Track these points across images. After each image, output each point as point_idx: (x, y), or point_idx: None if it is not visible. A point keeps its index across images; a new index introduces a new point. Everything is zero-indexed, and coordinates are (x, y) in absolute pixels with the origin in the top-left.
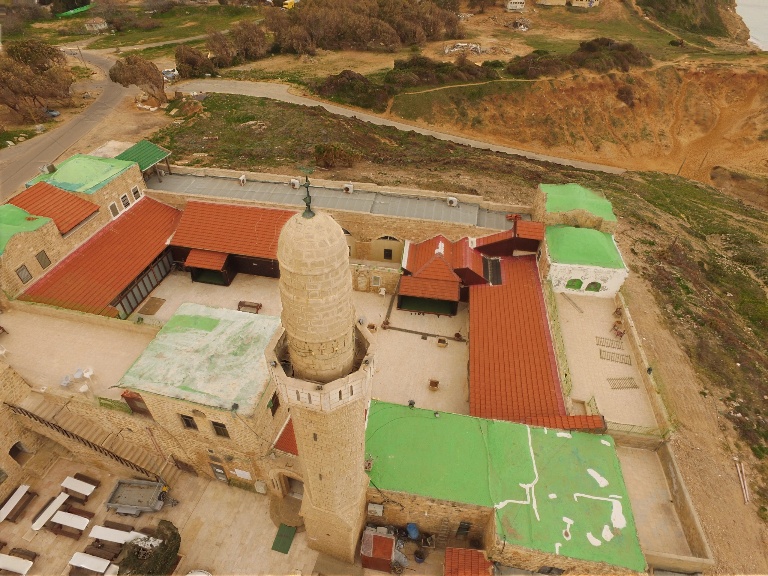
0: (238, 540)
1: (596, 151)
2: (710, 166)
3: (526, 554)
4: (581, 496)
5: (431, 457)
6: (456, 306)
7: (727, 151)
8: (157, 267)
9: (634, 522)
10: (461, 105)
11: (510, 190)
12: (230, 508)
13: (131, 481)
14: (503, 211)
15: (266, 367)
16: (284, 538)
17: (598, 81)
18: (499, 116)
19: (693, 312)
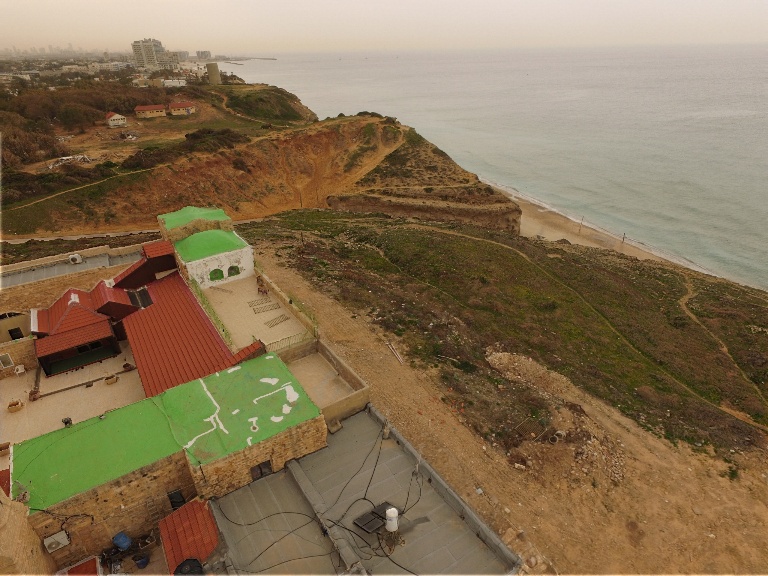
0: None
1: (237, 211)
2: (324, 198)
3: (226, 464)
4: (259, 399)
5: (104, 450)
6: (115, 343)
7: (330, 185)
8: None
9: (304, 391)
10: (85, 206)
11: None
12: None
13: None
14: (136, 251)
15: None
16: None
17: (212, 159)
18: (132, 206)
19: (332, 275)
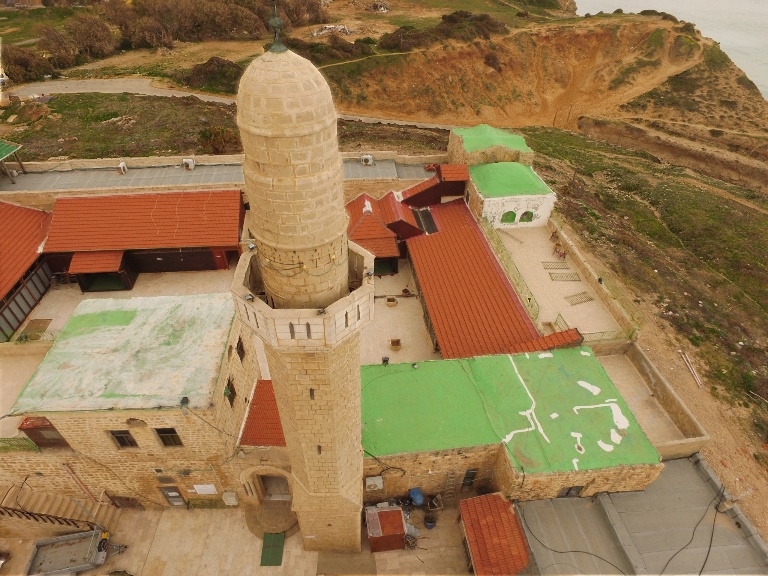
0: (216, 568)
1: (477, 115)
2: (575, 117)
3: (546, 480)
4: (580, 408)
5: (422, 409)
6: (396, 263)
7: (586, 102)
8: (31, 282)
9: (635, 419)
10: (342, 83)
11: (413, 153)
12: (196, 535)
13: (54, 540)
14: (420, 163)
15: (212, 349)
16: (273, 548)
17: (466, 50)
18: (382, 91)
19: (606, 234)
